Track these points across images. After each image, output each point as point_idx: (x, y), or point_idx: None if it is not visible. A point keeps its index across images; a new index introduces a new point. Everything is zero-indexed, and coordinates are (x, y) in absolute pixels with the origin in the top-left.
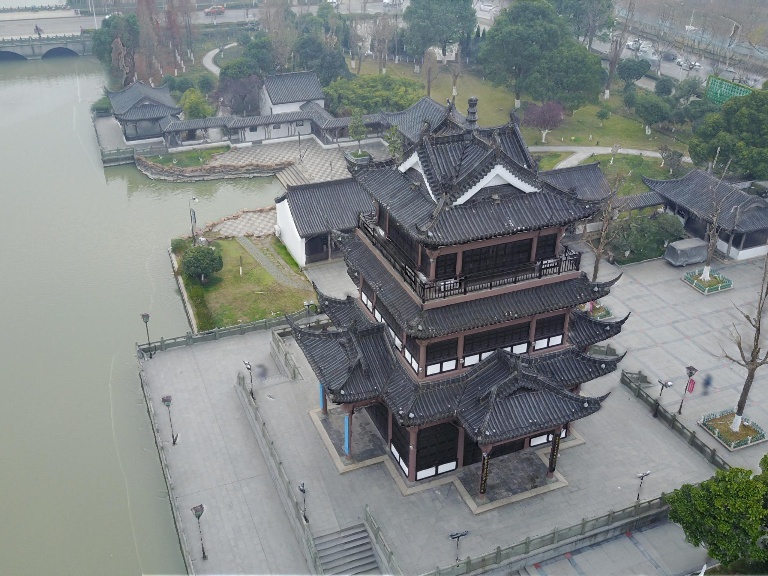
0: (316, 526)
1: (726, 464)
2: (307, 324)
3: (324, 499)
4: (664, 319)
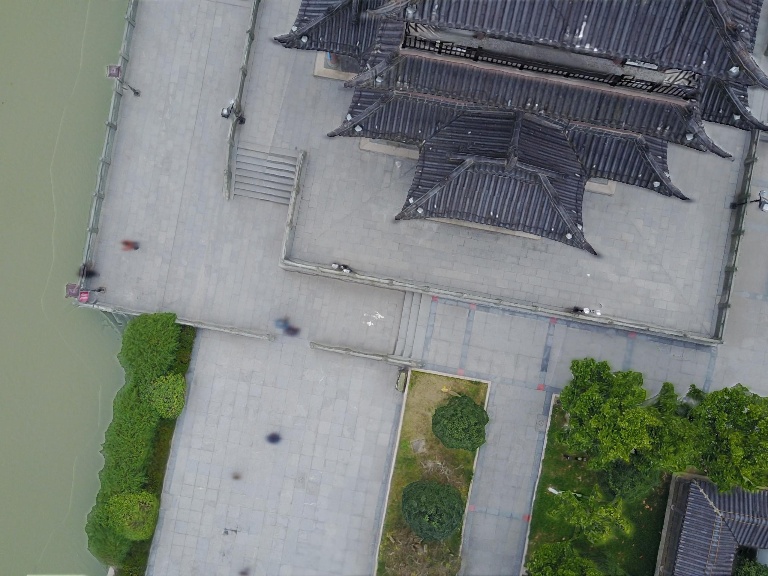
0: (248, 133)
1: (722, 327)
2: None
3: (276, 101)
4: None
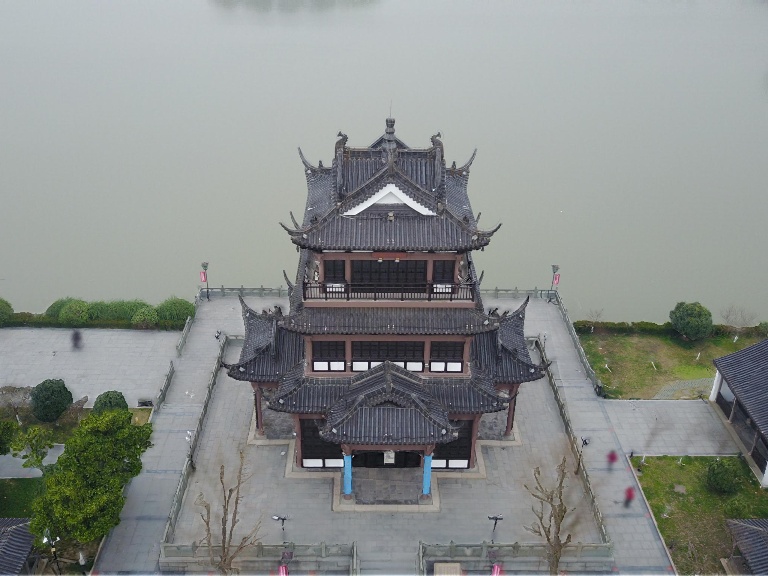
0: None
1: None
2: None
3: None
4: None
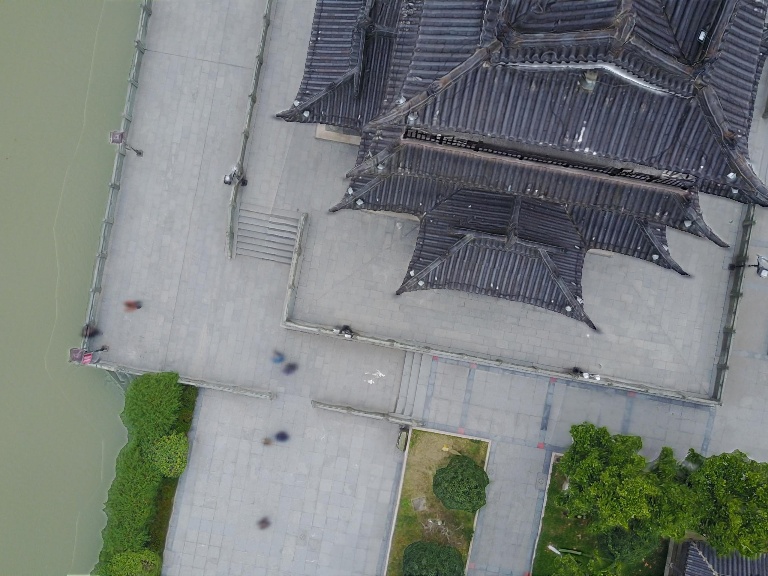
0: (250, 195)
1: (721, 389)
2: None
3: (278, 163)
4: None
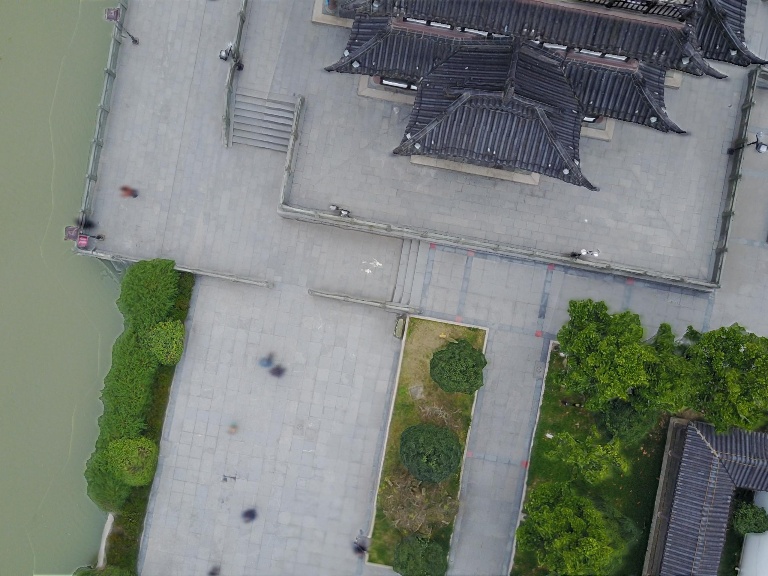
0: (247, 79)
1: (719, 272)
2: None
3: (275, 47)
4: None
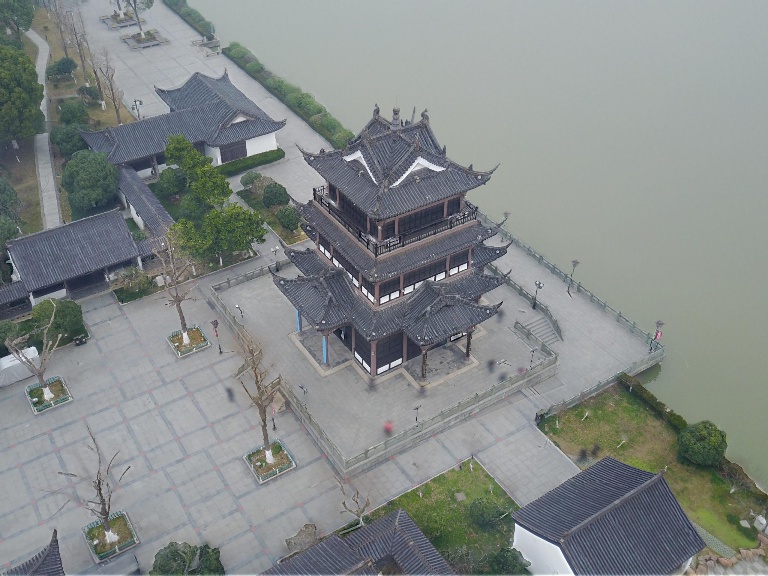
0: None
1: None
2: (534, 367)
3: None
4: (191, 463)
